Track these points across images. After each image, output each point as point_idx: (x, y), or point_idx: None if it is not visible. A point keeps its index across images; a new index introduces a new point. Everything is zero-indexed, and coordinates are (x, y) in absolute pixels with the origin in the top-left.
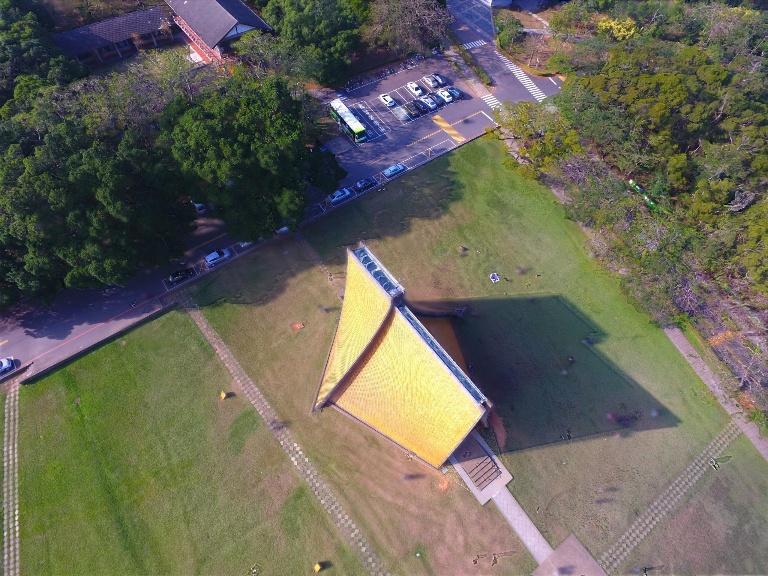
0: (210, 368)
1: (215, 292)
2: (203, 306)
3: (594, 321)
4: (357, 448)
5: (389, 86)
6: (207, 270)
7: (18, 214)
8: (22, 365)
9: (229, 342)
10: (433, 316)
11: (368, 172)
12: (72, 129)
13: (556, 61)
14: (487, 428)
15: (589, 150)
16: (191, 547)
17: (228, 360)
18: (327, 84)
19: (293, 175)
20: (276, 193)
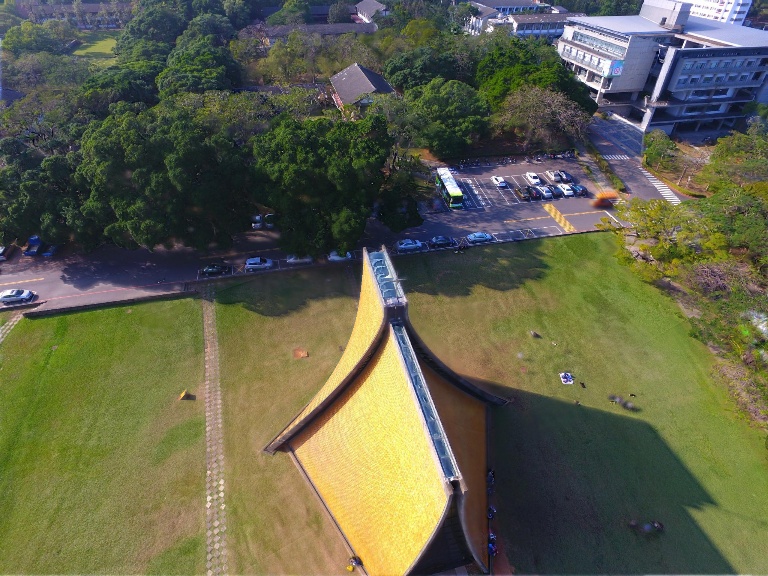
0: (189, 363)
1: (239, 294)
2: (220, 303)
3: (712, 485)
4: (290, 519)
5: (506, 172)
6: (243, 273)
7: (97, 158)
8: (37, 301)
9: (223, 345)
10: (459, 386)
11: (451, 234)
12: (184, 116)
13: (711, 171)
14: (484, 572)
15: (740, 260)
16: (34, 555)
17: (211, 362)
18: (441, 155)
19: (359, 197)
20: (335, 210)
